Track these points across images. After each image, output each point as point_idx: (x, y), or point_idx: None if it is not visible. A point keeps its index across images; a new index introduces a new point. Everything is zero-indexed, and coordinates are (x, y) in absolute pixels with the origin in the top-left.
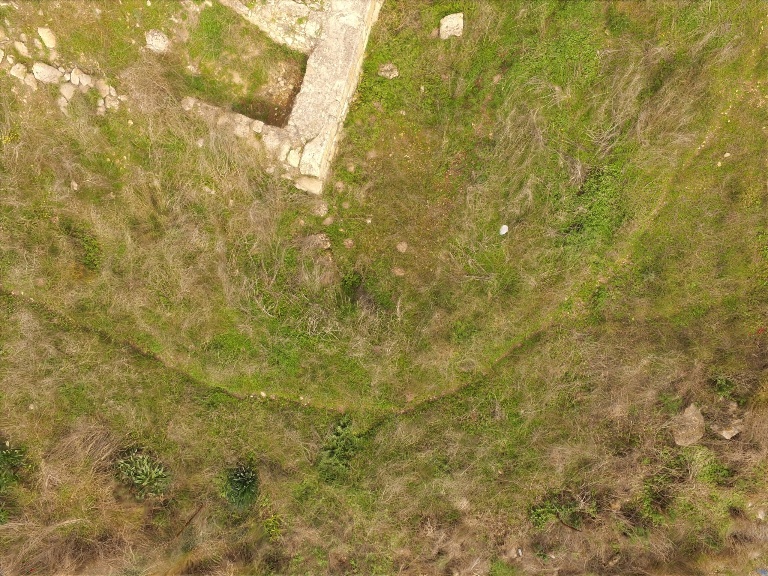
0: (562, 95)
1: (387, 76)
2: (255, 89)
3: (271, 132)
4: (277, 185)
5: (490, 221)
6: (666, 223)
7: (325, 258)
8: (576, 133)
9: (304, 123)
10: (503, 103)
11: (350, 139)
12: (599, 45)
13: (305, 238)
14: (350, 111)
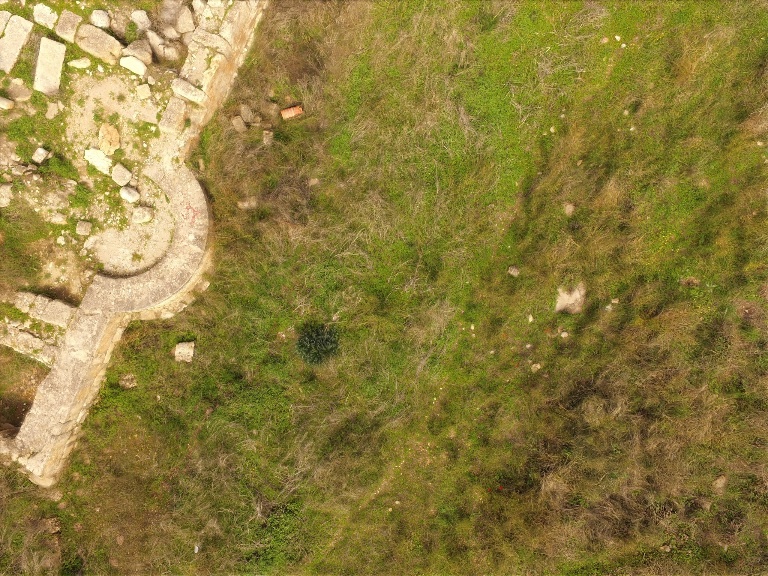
0: (252, 444)
1: (127, 385)
2: (6, 387)
3: (2, 442)
4: (12, 478)
5: (187, 538)
6: (339, 556)
7: (52, 542)
8: (267, 472)
9: (29, 440)
10: (209, 437)
11: (87, 438)
12: (293, 399)
13: (30, 528)
14: (90, 413)
